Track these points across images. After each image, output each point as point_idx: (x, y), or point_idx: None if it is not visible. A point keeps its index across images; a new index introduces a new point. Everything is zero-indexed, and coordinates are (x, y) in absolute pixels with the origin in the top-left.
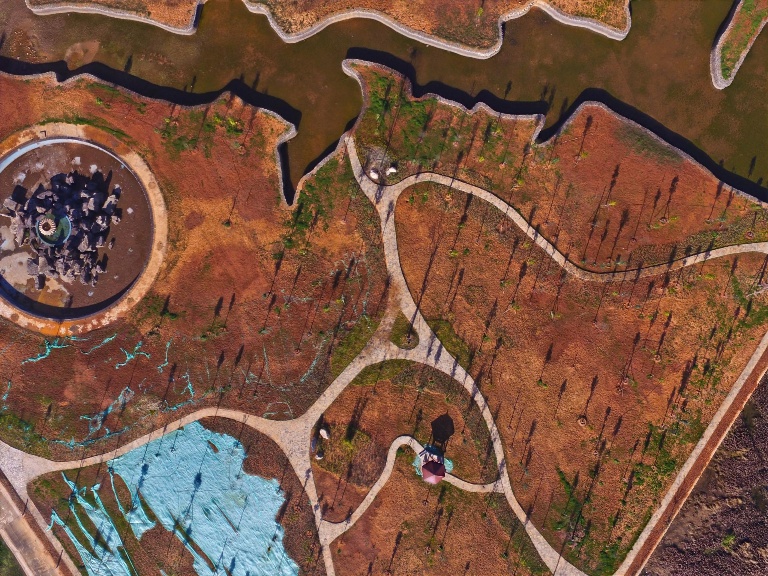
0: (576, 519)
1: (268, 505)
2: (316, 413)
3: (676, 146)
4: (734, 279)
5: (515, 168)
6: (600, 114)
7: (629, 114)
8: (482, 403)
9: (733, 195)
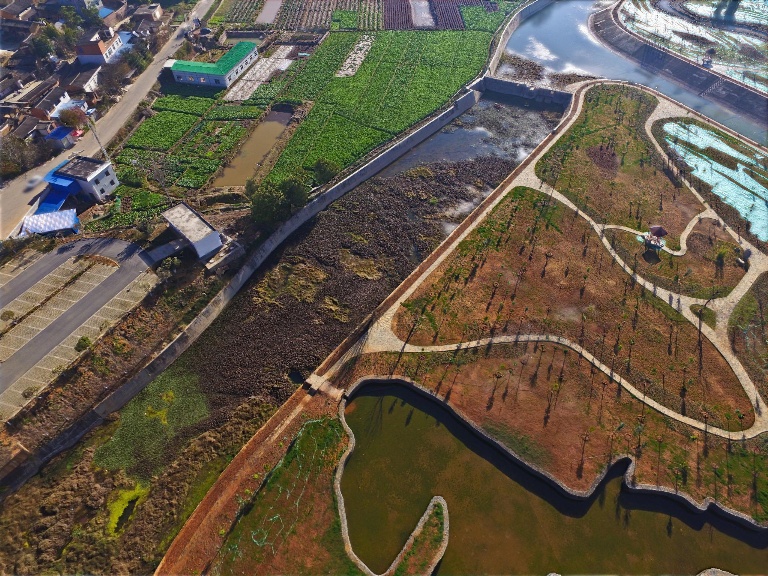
0: (544, 210)
1: (760, 229)
2: (752, 273)
3: (480, 446)
4: (436, 329)
5: (646, 435)
6: (569, 481)
7: (531, 484)
8: (627, 269)
9: (435, 390)
